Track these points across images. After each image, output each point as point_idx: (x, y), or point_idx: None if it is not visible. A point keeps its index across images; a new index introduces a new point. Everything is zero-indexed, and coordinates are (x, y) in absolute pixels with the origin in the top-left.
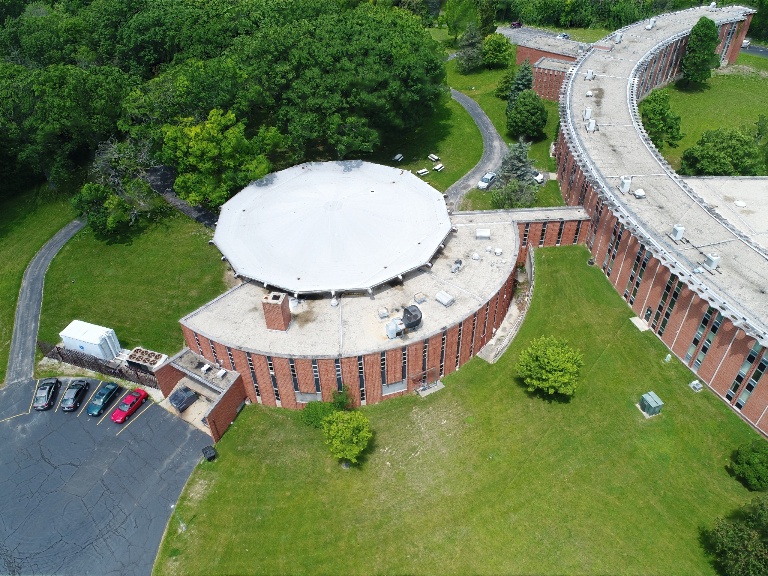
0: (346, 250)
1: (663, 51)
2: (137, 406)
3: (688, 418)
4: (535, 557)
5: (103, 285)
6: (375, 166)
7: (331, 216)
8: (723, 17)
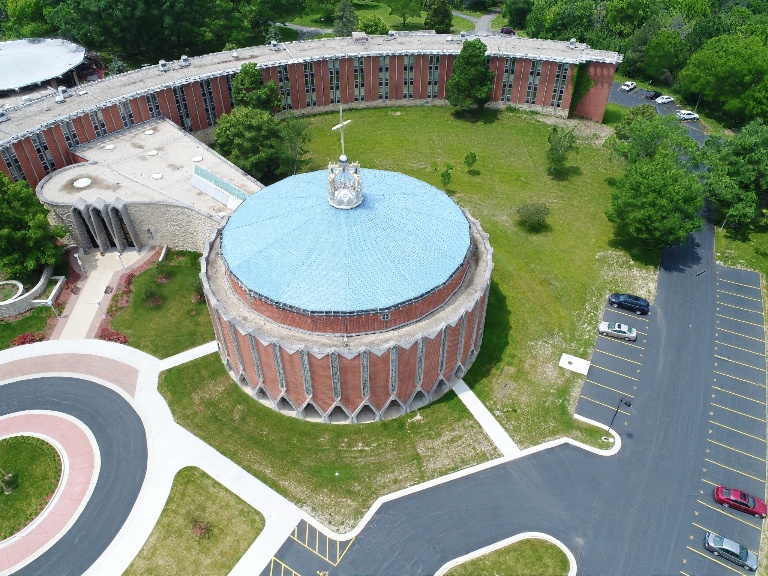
0: None
1: (421, 61)
2: None
3: None
4: None
5: None
6: None
7: None
8: (557, 54)
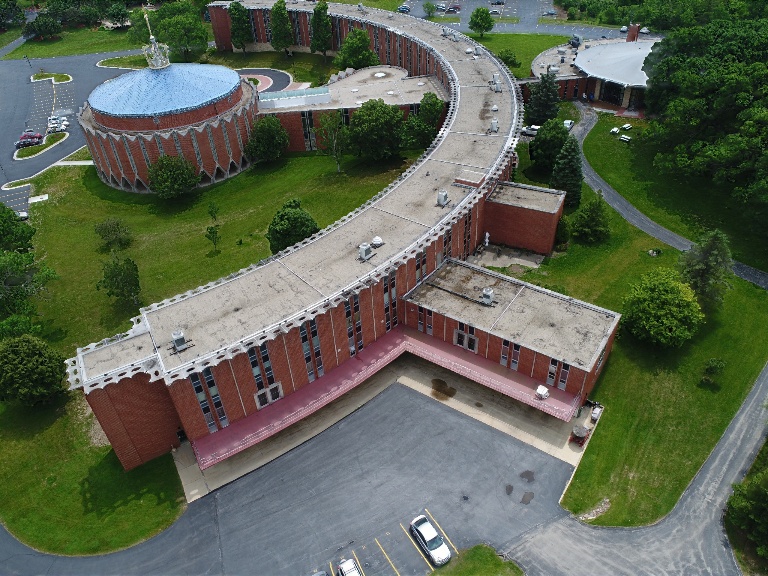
0: None
1: None
2: None
3: None
4: None
5: None
6: None
7: None
8: (189, 308)
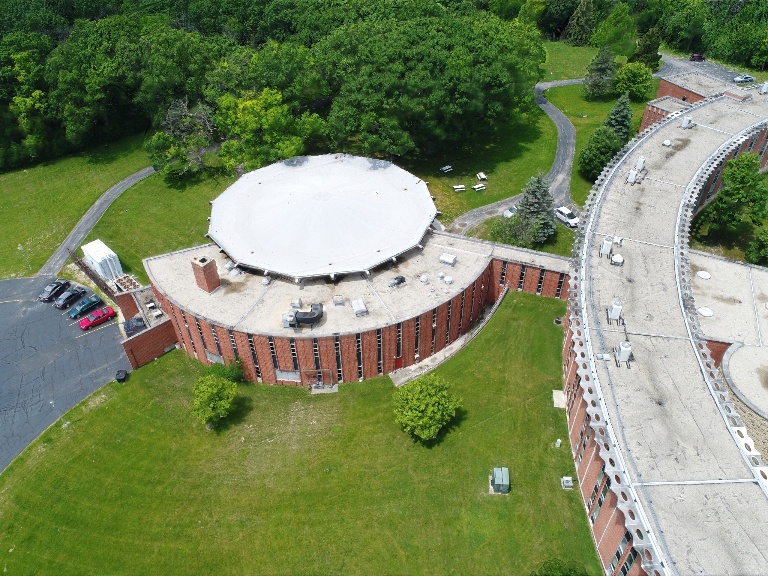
0: (308, 239)
1: None
2: (102, 321)
3: (533, 511)
4: (297, 573)
5: (143, 219)
6: (399, 170)
7: (313, 205)
8: None
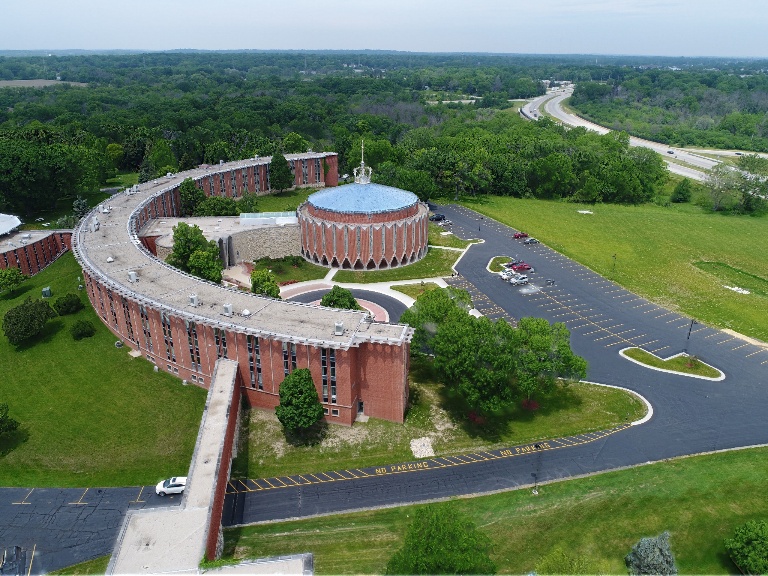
0: None
1: (250, 171)
2: None
3: None
4: None
5: None
6: (0, 215)
7: None
8: None
